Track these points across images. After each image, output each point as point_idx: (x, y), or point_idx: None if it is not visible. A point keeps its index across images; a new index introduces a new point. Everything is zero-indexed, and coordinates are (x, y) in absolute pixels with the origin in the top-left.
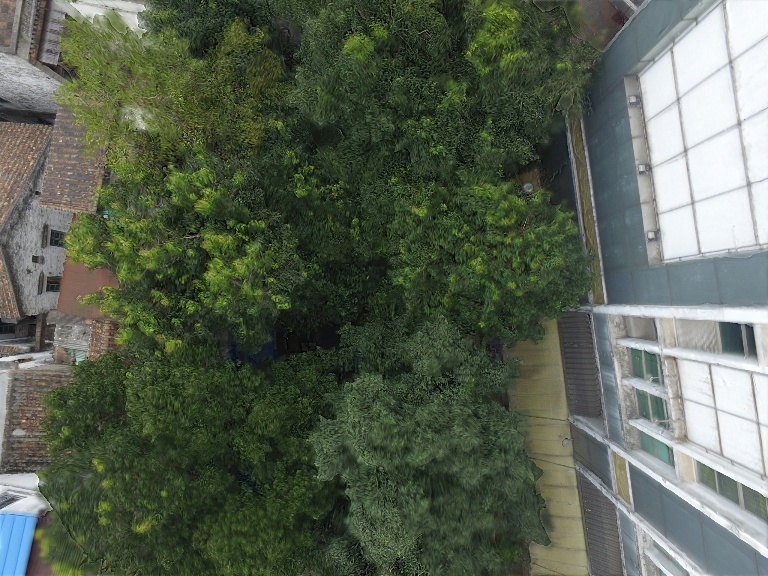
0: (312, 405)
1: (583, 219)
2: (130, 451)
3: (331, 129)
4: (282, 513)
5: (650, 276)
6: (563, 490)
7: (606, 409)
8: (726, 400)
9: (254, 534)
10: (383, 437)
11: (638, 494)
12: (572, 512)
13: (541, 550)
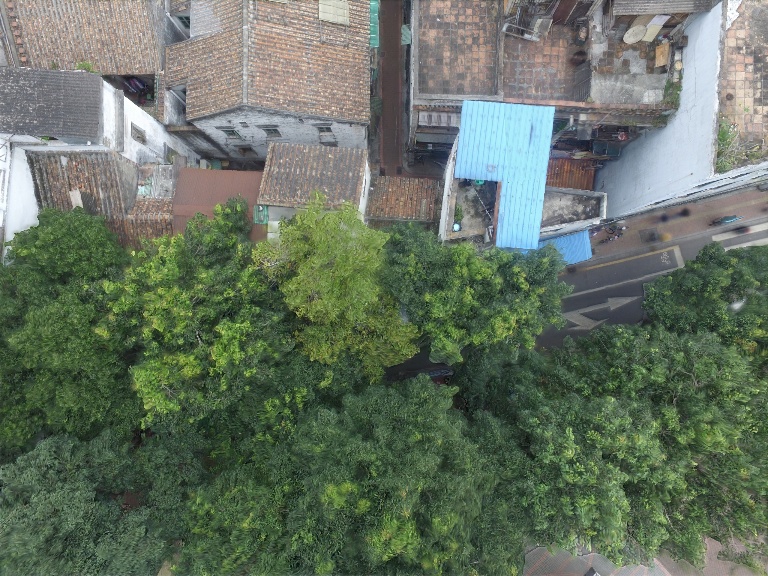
0: (98, 419)
1: None
2: (0, 322)
3: None
4: None
5: None
6: None
7: None
8: None
9: None
10: None
11: None
12: None
13: None
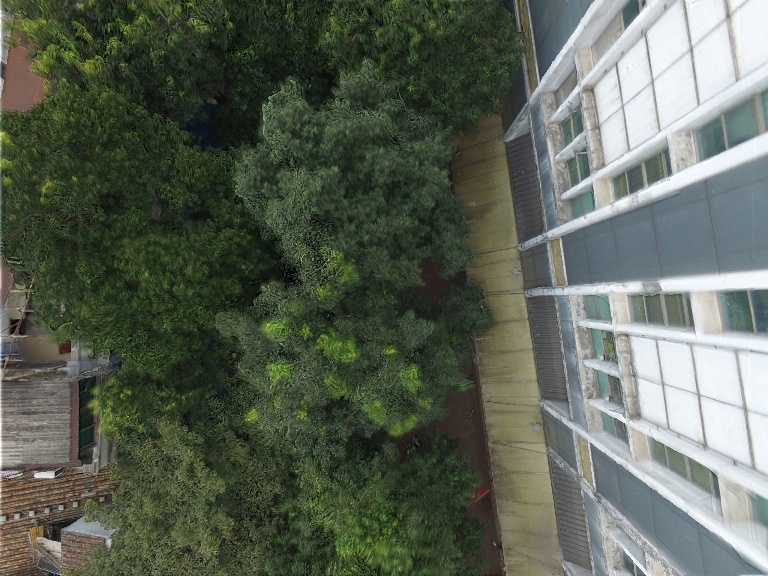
0: None
1: (520, 18)
2: None
3: None
4: (207, 249)
5: (568, 12)
6: (515, 324)
7: (544, 203)
8: (629, 87)
9: (175, 253)
10: (291, 122)
11: (570, 264)
12: (524, 344)
13: (495, 388)
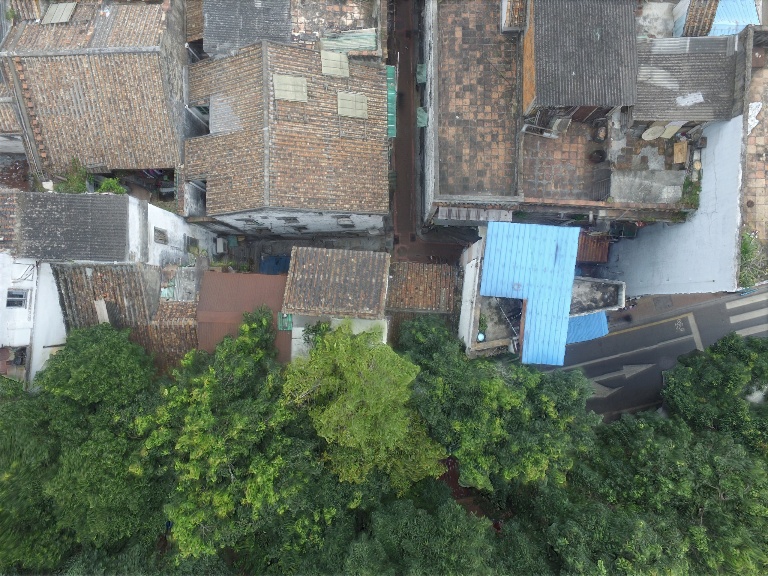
0: None
1: None
2: None
3: (390, 497)
4: None
5: None
6: None
7: None
8: None
9: None
10: None
11: None
12: None
13: None
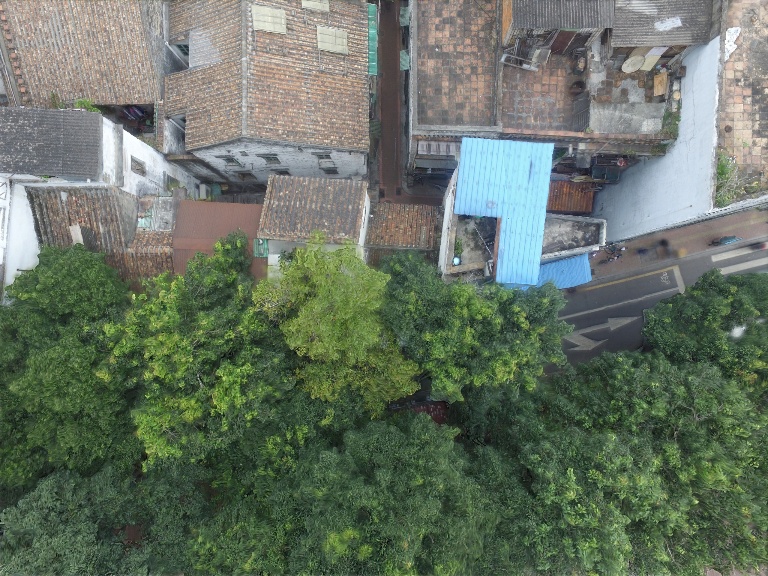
0: (100, 456)
1: None
2: (1, 368)
3: None
4: None
5: None
6: None
7: None
8: None
9: None
10: None
11: None
12: None
13: None
